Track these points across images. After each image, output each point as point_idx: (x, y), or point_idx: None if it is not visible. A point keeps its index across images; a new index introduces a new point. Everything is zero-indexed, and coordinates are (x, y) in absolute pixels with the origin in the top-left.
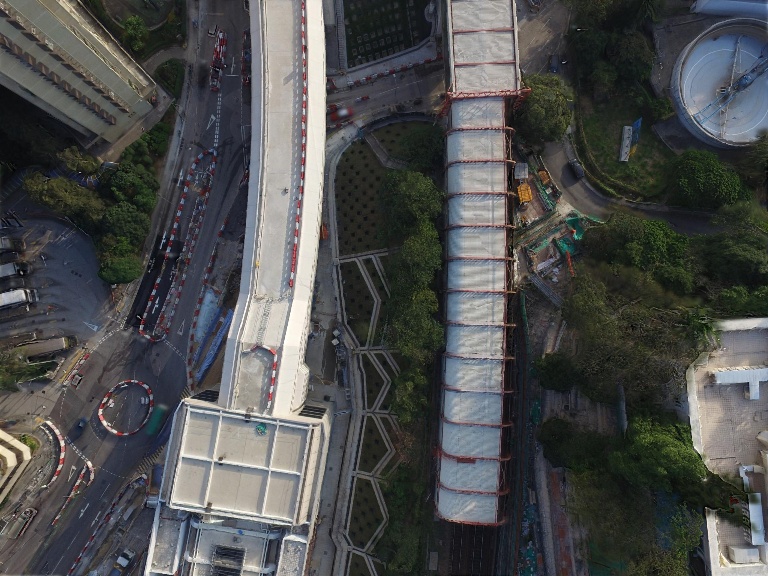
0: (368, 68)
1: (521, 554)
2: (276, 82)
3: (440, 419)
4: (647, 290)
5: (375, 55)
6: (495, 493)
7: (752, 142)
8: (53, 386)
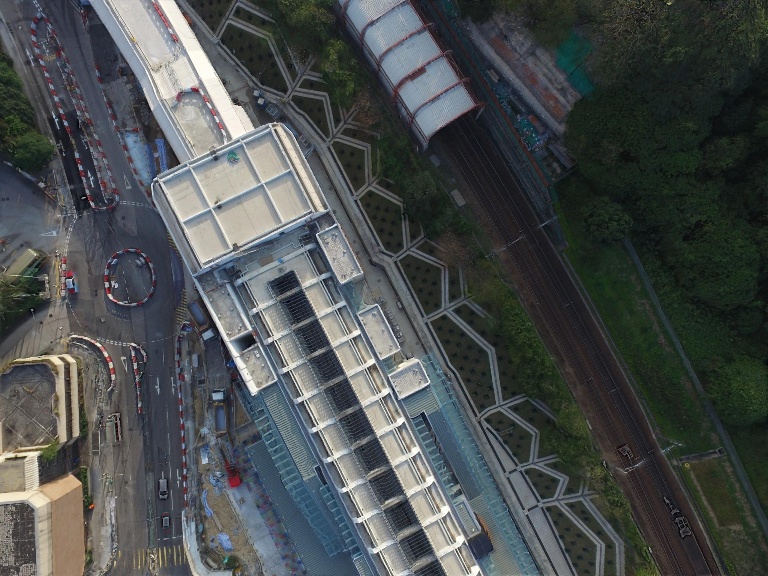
0: None
1: (517, 130)
2: None
3: (381, 77)
4: None
5: None
6: (458, 83)
7: None
8: (55, 305)
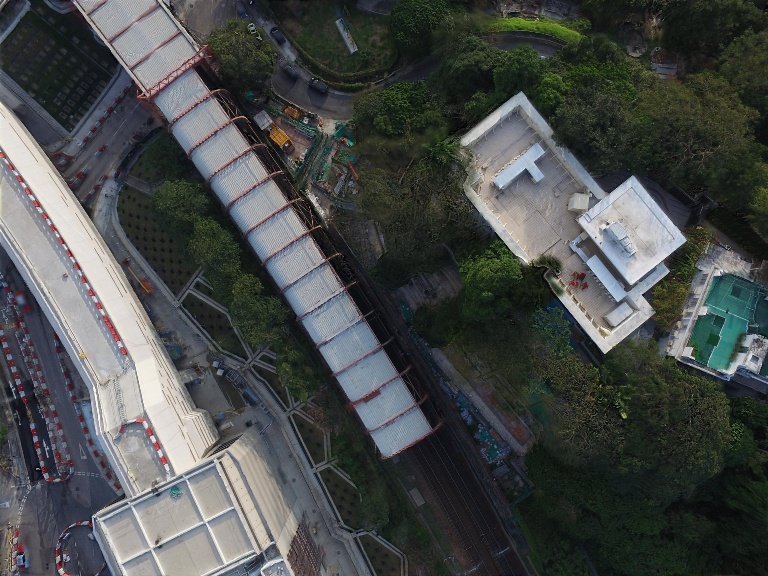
0: (88, 121)
1: (478, 440)
2: None
3: None
4: (414, 149)
5: (84, 106)
6: (414, 406)
7: None
8: None
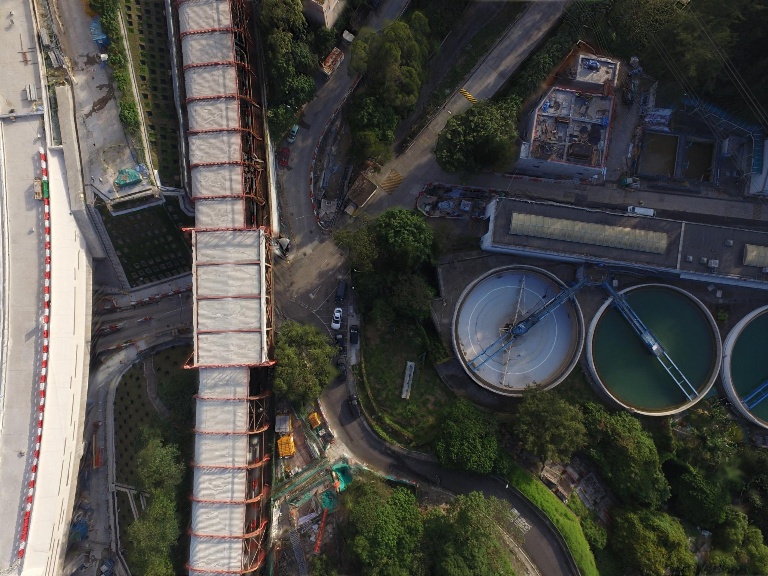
0: (153, 287)
1: None
2: (17, 338)
3: None
4: None
5: (158, 276)
6: None
7: (527, 390)
8: None
